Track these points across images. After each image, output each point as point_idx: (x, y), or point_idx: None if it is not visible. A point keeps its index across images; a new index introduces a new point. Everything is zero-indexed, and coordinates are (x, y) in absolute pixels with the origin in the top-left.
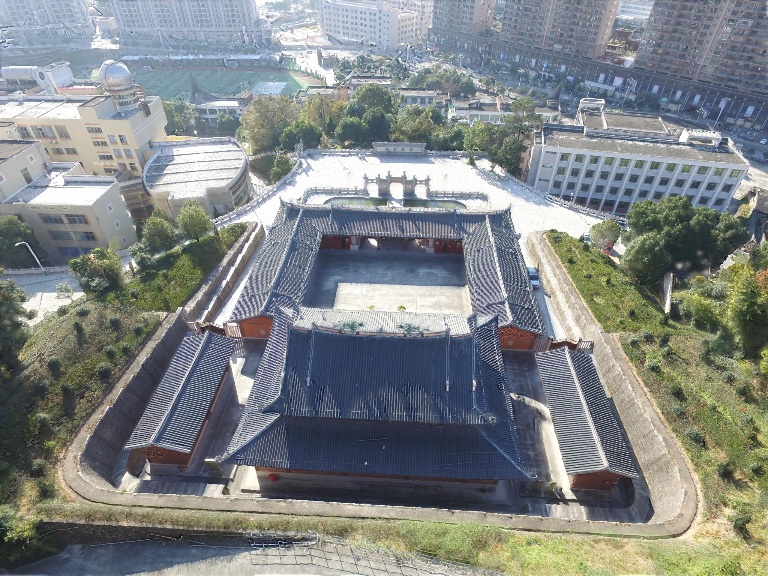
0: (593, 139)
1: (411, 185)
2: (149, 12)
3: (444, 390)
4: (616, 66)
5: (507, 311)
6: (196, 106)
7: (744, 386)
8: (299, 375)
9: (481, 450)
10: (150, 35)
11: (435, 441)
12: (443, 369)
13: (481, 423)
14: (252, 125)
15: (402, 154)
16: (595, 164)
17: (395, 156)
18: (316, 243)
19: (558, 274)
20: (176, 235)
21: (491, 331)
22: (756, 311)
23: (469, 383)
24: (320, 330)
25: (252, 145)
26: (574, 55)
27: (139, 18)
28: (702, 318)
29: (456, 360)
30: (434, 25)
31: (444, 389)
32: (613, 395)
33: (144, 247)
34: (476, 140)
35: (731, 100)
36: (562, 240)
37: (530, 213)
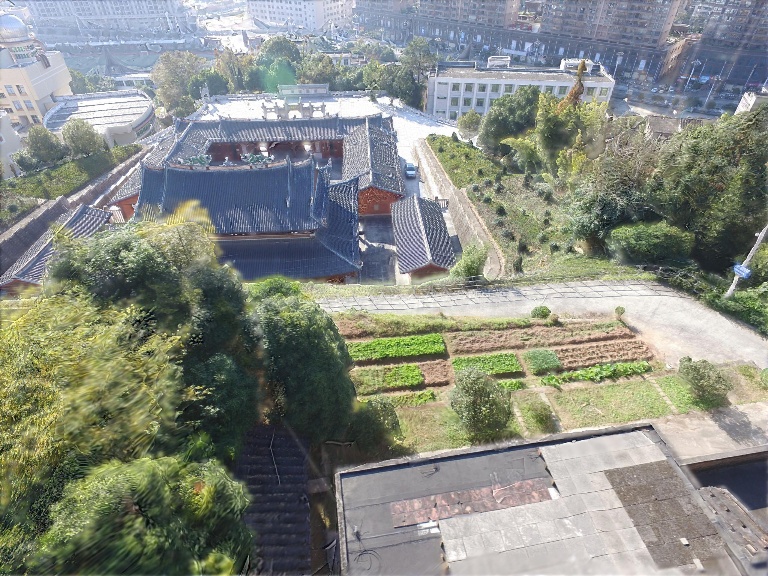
0: (482, 72)
1: (308, 112)
2: (65, 0)
3: (285, 207)
4: (525, 32)
5: (370, 177)
6: (111, 78)
7: (546, 192)
8: (153, 205)
9: (321, 256)
10: (66, 22)
11: (281, 253)
12: (285, 191)
13: (316, 227)
14: (162, 81)
15: (308, 96)
16: (483, 92)
17: (301, 98)
18: (203, 148)
19: (430, 162)
20: (62, 146)
21: (350, 188)
22: (550, 127)
23: (308, 200)
24: (172, 168)
25: (164, 103)
26: (487, 24)
27: (54, 7)
28: (525, 156)
29: (297, 184)
30: (357, 5)
31: (285, 206)
32: (458, 232)
33: (27, 153)
34: (375, 78)
35: (626, 56)
36: (438, 138)
37: (421, 132)
